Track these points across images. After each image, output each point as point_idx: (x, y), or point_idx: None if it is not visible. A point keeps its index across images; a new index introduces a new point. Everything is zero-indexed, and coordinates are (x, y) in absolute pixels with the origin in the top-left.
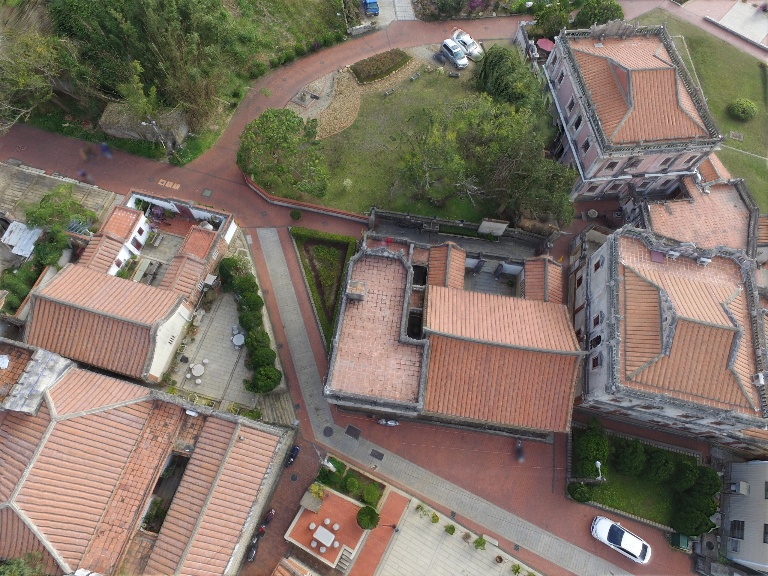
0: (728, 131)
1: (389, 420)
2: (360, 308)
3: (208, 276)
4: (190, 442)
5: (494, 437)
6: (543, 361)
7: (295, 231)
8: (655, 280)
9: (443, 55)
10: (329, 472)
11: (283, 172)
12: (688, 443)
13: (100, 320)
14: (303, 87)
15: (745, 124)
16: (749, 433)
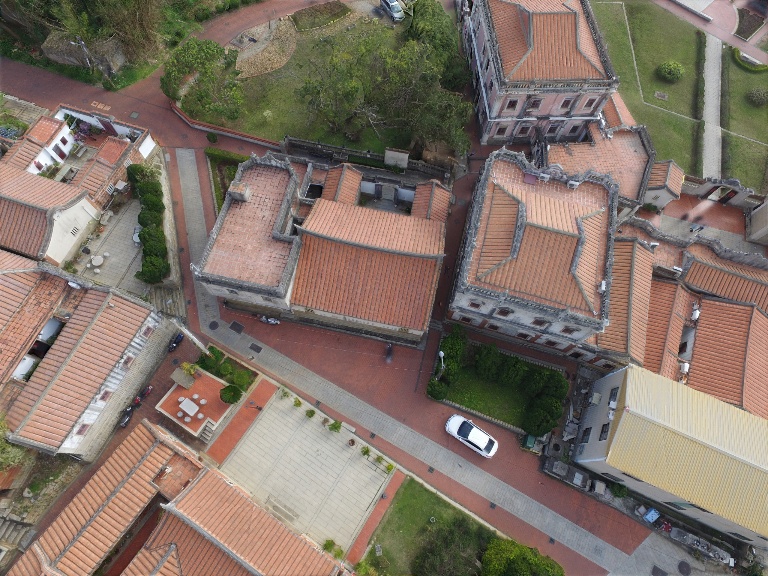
0: (653, 91)
1: (270, 318)
2: (243, 208)
3: (119, 182)
4: (71, 311)
5: (368, 341)
6: (407, 264)
7: (209, 151)
8: (520, 196)
9: (382, 9)
10: (206, 357)
11: (202, 96)
12: (557, 361)
13: (6, 204)
14: (243, 31)
15: (672, 85)
16: (604, 346)
